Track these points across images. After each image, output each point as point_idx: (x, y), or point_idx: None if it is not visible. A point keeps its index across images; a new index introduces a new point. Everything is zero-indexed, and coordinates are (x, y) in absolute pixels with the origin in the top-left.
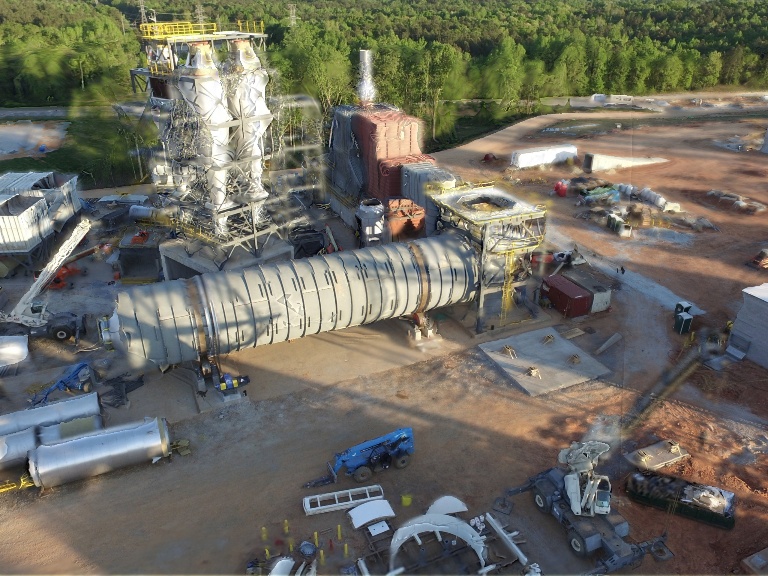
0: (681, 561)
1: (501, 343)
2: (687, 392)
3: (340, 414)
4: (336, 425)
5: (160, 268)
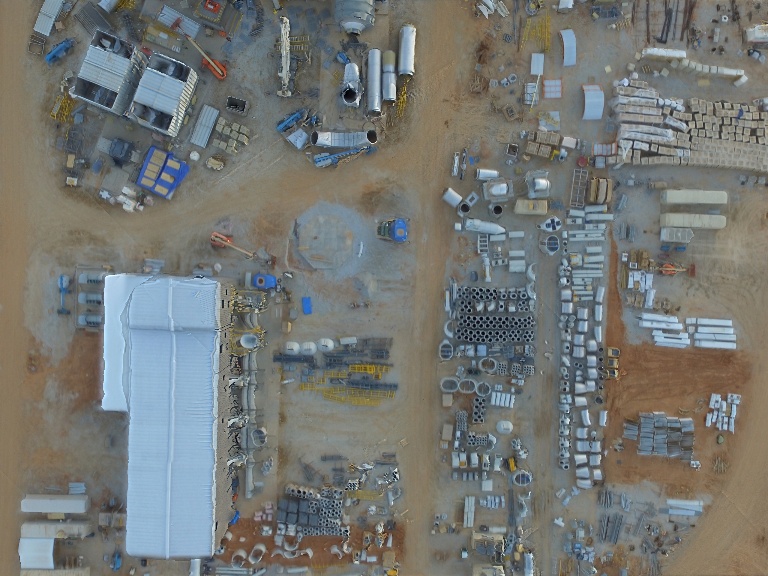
0: None
1: None
2: None
3: None
4: None
5: (233, 6)
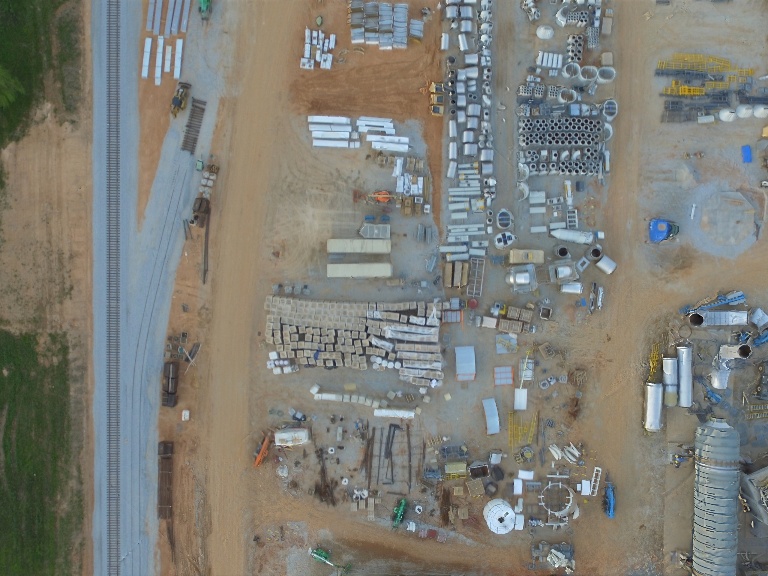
0: (527, 570)
1: None
2: None
3: (642, 497)
4: (636, 493)
5: None
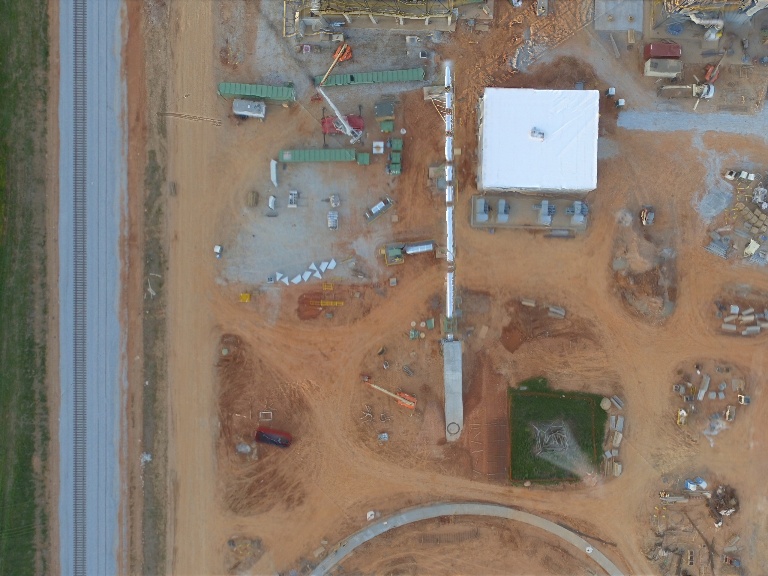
0: None
1: None
2: (568, 49)
3: None
4: None
5: None
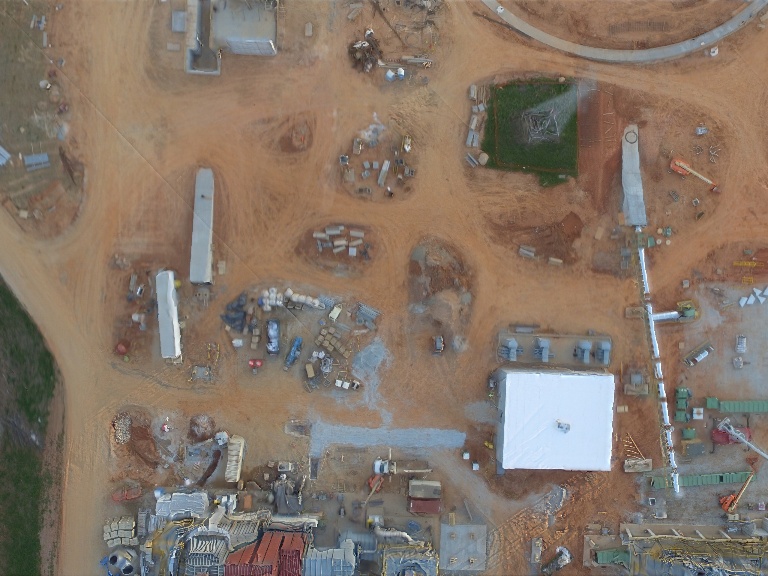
0: None
1: (443, 558)
2: (514, 507)
3: None
4: None
5: None
